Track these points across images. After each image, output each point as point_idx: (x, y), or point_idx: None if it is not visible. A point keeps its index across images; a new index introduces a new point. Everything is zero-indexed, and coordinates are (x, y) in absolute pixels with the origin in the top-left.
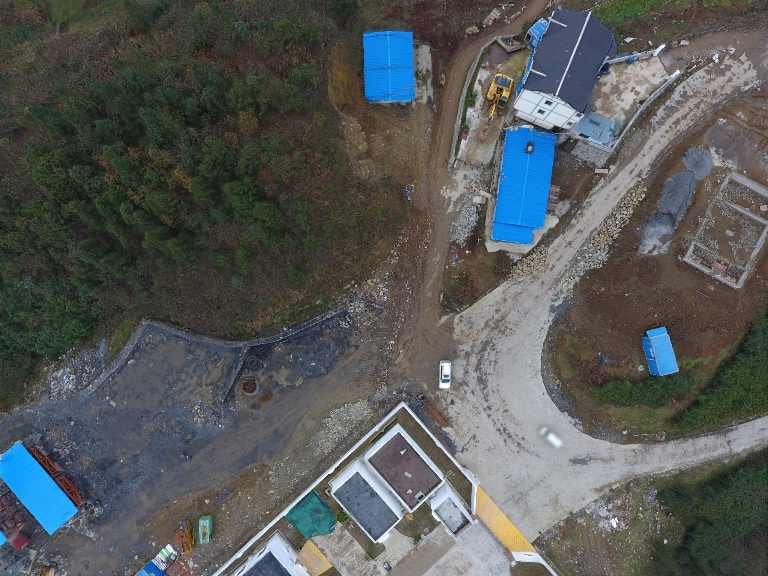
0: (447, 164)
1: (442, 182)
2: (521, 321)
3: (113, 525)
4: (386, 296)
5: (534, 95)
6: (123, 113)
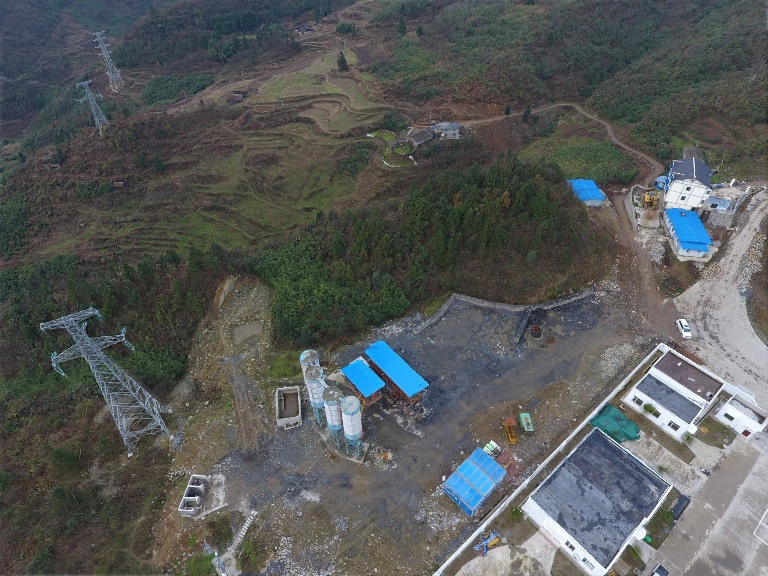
0: (632, 229)
1: (633, 235)
2: (723, 301)
3: (438, 426)
4: (619, 288)
5: (679, 185)
6: (472, 176)
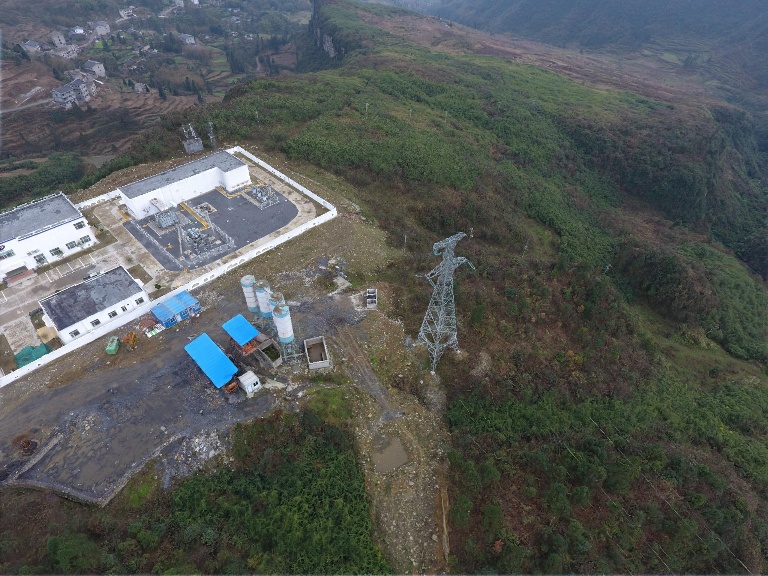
0: None
1: None
2: None
3: None
4: None
5: None
6: None
